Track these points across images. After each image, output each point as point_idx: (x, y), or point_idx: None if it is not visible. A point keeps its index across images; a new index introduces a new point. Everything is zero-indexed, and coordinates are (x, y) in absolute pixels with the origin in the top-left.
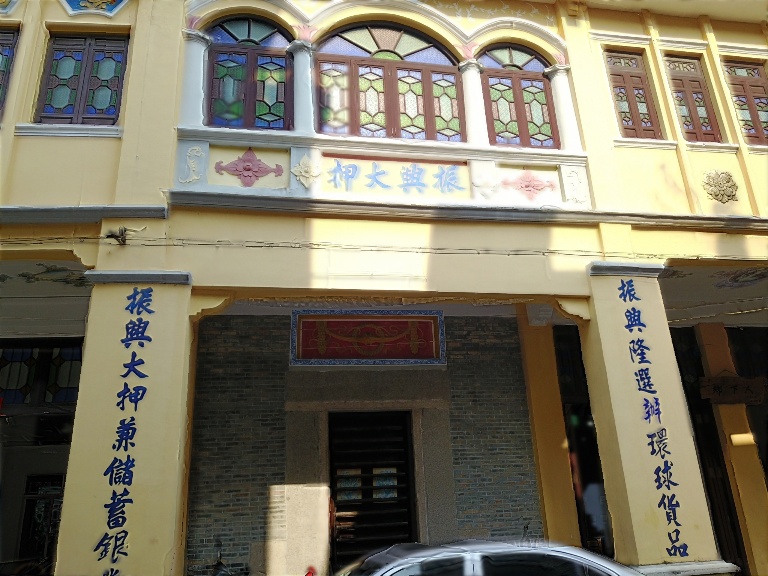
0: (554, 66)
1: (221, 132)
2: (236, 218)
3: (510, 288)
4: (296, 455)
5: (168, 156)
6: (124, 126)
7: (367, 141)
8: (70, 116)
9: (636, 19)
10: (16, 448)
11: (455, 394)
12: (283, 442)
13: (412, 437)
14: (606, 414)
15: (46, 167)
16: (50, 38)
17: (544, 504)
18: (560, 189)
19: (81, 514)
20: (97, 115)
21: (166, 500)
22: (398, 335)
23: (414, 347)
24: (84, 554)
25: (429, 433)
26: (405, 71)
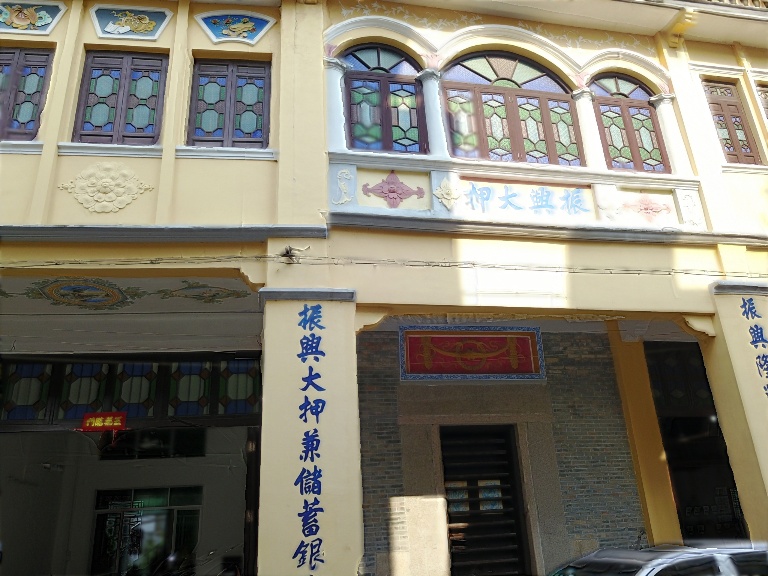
0: (660, 95)
1: (368, 156)
2: (390, 238)
3: (643, 306)
4: (412, 467)
5: (323, 179)
6: (279, 150)
7: (501, 165)
8: (221, 139)
9: (729, 51)
10: (111, 462)
11: (556, 408)
12: (399, 455)
13: (518, 450)
14: (739, 426)
15: (207, 188)
16: (194, 65)
17: (648, 515)
18: (676, 212)
19: (277, 523)
20: (246, 139)
21: (354, 509)
22: (498, 350)
23: (514, 362)
24: (284, 561)
25: (535, 446)
26: (524, 99)
